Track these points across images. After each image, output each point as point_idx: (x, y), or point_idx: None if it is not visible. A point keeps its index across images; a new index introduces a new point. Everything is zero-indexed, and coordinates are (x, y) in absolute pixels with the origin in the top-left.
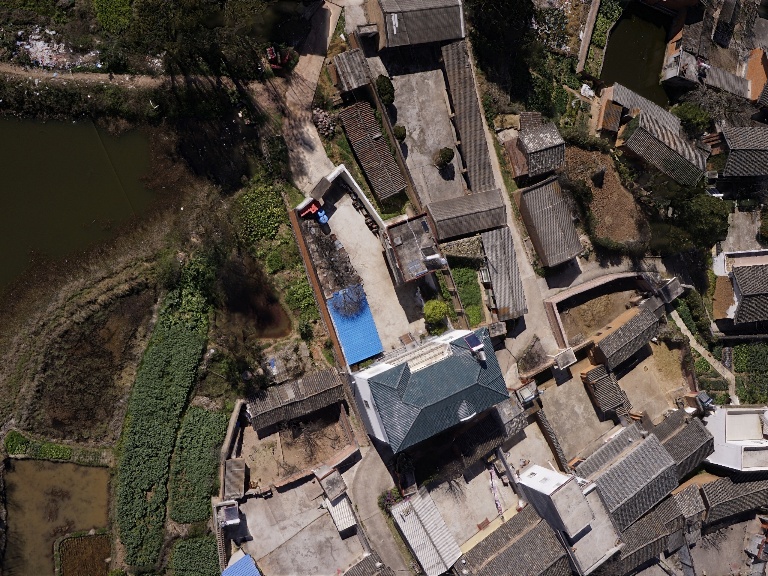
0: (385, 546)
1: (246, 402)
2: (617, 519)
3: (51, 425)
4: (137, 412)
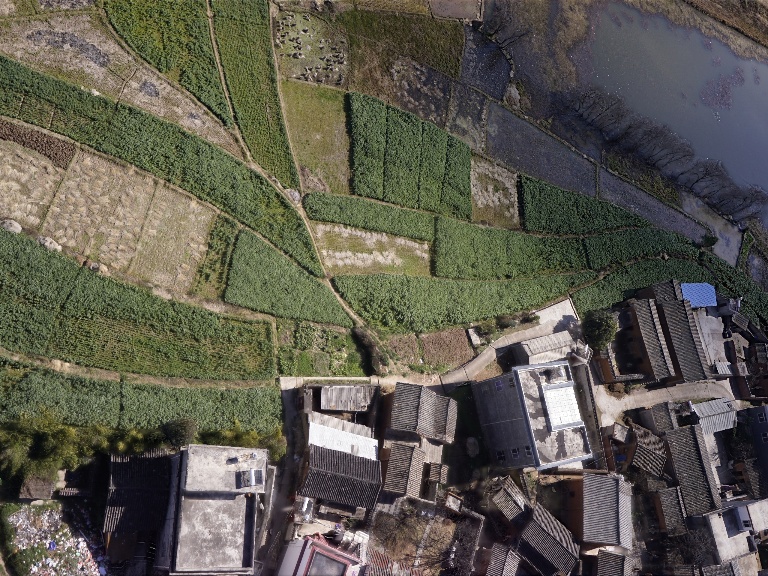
0: (693, 391)
1: (767, 346)
2: (721, 572)
3: (752, 256)
4: (762, 293)
